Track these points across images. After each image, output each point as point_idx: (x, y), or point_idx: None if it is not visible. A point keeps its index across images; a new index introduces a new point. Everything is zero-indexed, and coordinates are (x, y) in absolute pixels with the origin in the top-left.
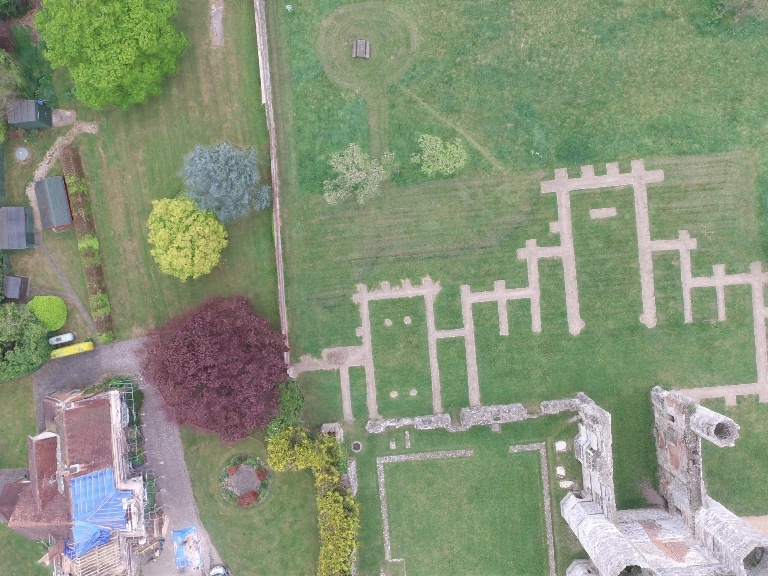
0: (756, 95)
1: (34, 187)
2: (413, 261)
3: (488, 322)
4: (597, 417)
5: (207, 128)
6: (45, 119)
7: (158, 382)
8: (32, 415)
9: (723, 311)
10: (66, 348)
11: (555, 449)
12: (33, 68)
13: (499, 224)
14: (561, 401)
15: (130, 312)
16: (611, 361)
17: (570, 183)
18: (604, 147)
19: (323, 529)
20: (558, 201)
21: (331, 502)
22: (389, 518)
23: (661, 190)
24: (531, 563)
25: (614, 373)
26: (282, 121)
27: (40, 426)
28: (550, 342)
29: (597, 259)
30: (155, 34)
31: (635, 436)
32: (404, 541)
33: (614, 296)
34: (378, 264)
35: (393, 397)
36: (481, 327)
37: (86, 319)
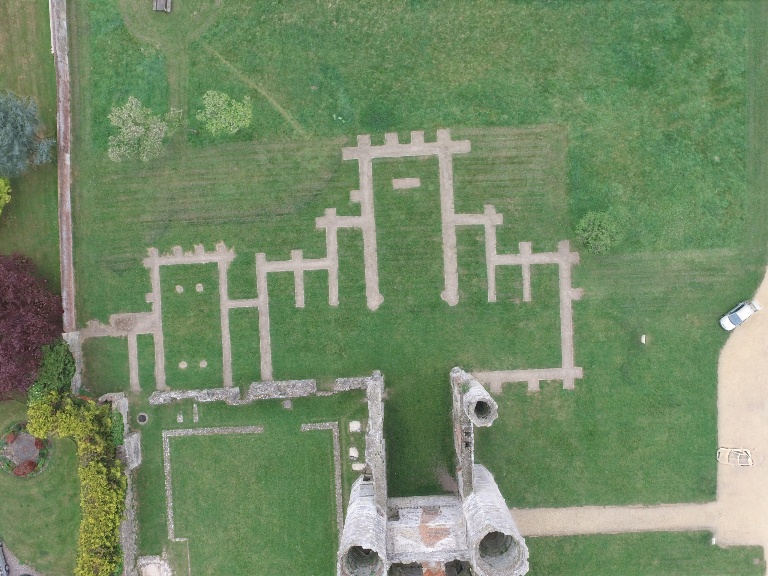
0: (570, 66)
1: None
2: (207, 226)
3: (283, 293)
4: (367, 393)
5: (1, 79)
6: None
7: None
8: None
9: (528, 291)
10: None
11: (349, 429)
12: None
13: (298, 190)
14: (355, 379)
15: None
16: (410, 339)
17: (373, 150)
18: (410, 114)
19: (84, 501)
20: (360, 169)
21: (94, 473)
22: (173, 495)
23: (467, 161)
24: (320, 548)
25: (413, 352)
26: (78, 74)
27: None
28: (347, 316)
29: (398, 231)
30: None
31: (432, 419)
32: (188, 520)
33: (415, 271)
34: (171, 227)
35: (182, 368)
36: (276, 298)
37: None
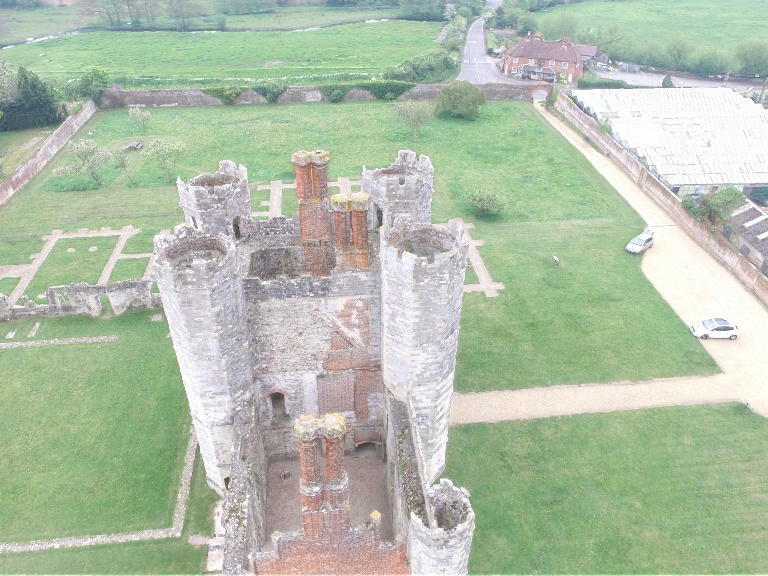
0: None
1: None
2: (121, 219)
3: None
4: None
5: None
6: None
7: None
8: None
9: None
10: None
11: None
12: None
13: None
14: None
15: None
16: None
17: (284, 186)
18: None
19: None
20: (271, 193)
21: None
22: None
23: None
24: (154, 458)
25: None
26: None
27: None
28: None
29: None
30: None
31: None
32: None
33: None
34: (84, 220)
35: (40, 298)
36: None
37: None
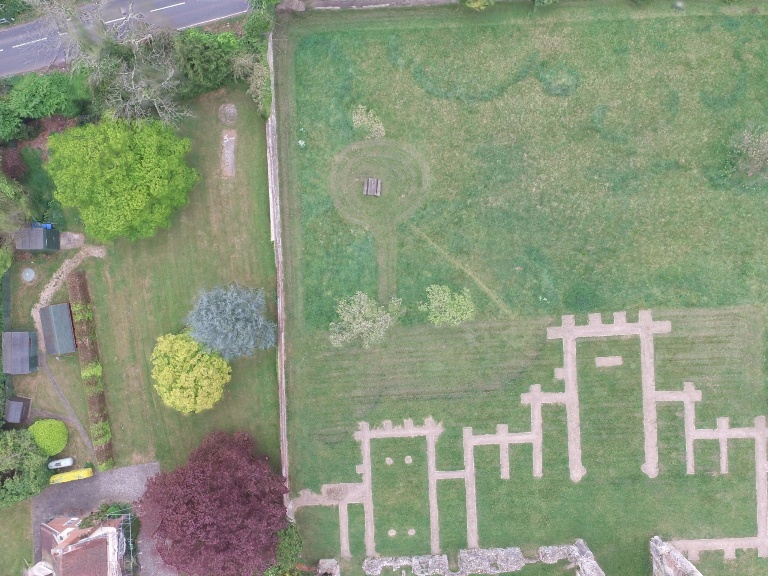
0: (767, 250)
1: (39, 310)
2: (416, 401)
3: (489, 465)
4: None
5: (215, 258)
6: (53, 244)
7: (156, 541)
8: (29, 537)
9: (725, 464)
10: (65, 475)
11: None
12: (43, 190)
13: (504, 368)
14: (559, 548)
15: (131, 438)
16: (611, 509)
17: (577, 330)
18: (612, 295)
19: None
20: (564, 347)
21: None
22: None
23: (668, 341)
24: None
25: (614, 521)
26: (290, 255)
27: (36, 553)
28: (551, 487)
29: (601, 407)
30: (166, 179)
31: None
32: None
33: (617, 445)
34: (381, 402)
35: (391, 535)
36: (482, 470)
37: (86, 443)
